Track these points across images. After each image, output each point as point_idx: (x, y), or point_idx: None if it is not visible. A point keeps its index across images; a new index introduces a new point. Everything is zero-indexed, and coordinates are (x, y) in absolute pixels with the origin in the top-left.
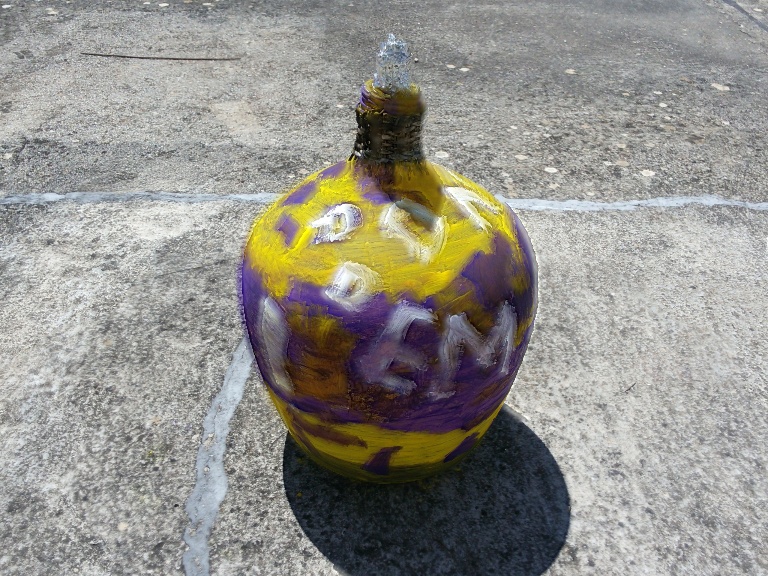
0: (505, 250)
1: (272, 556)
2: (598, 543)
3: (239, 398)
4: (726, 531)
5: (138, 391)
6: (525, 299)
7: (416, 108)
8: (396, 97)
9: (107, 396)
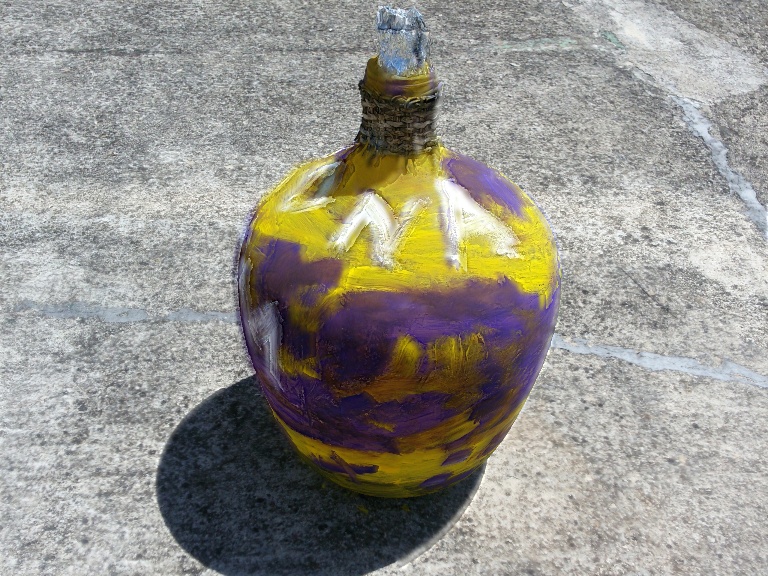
0: (322, 273)
1: (244, 353)
2: None
3: None
4: None
5: None
6: (302, 333)
7: (382, 87)
8: (381, 65)
9: None
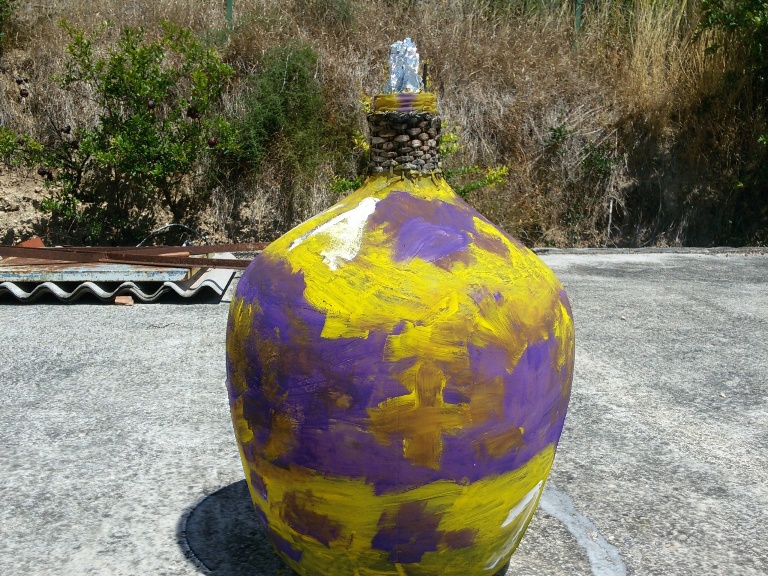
0: None
1: None
2: (177, 496)
3: (595, 569)
4: (37, 509)
5: (732, 571)
6: None
7: None
8: None
9: (762, 564)
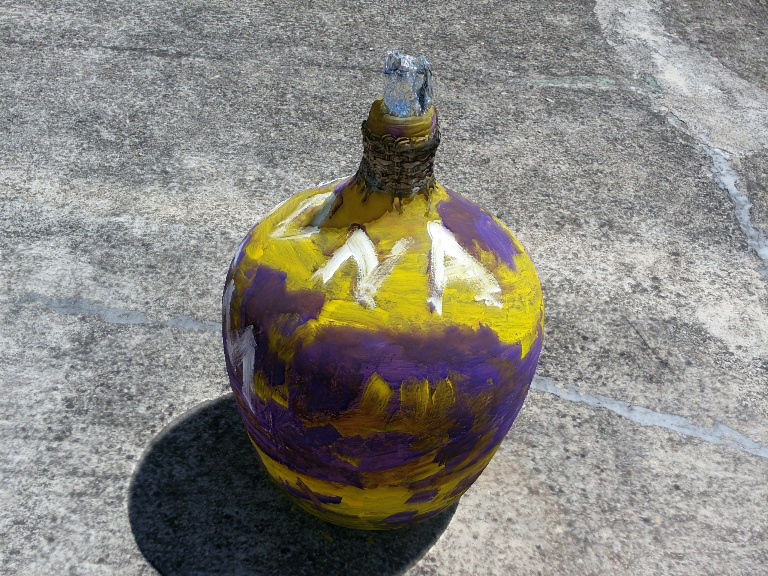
0: (298, 303)
1: None
2: None
3: None
4: None
5: None
6: (273, 360)
7: None
8: (376, 102)
9: None
